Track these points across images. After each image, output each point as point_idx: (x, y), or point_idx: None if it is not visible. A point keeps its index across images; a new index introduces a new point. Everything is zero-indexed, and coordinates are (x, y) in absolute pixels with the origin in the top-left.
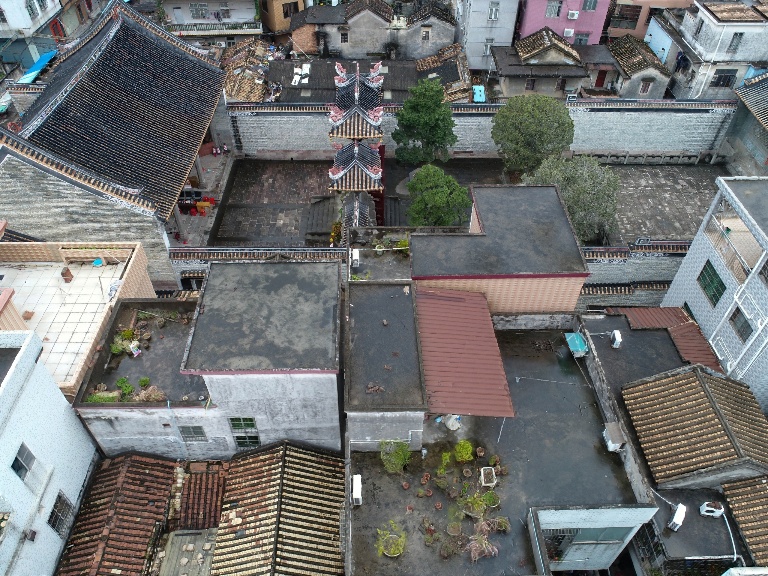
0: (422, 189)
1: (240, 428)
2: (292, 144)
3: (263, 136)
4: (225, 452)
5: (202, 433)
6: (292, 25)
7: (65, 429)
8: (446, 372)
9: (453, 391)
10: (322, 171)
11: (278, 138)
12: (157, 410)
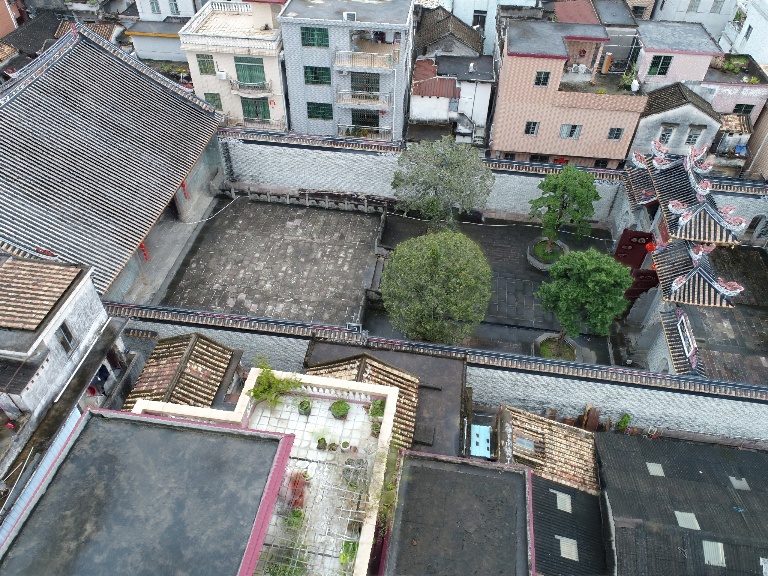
0: None
1: None
2: None
3: None
4: None
5: None
6: None
7: None
8: None
9: (579, 4)
10: None
11: None
12: None
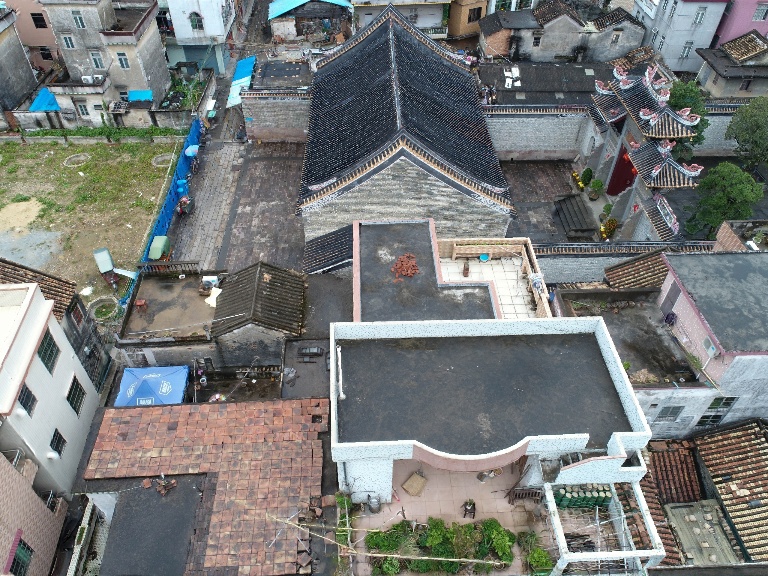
0: (726, 185)
1: (715, 407)
2: (516, 145)
3: (491, 137)
4: (680, 431)
5: (676, 413)
6: (485, 30)
7: None
8: None
9: None
10: (547, 170)
11: (505, 139)
12: (660, 391)
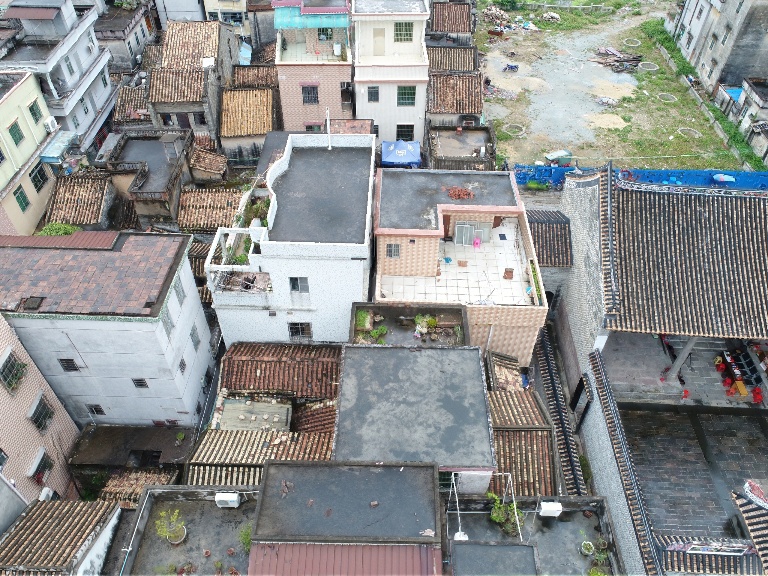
0: None
1: None
2: None
3: None
4: None
5: None
6: None
7: (345, 308)
8: (304, 572)
9: None
10: None
11: None
12: None
